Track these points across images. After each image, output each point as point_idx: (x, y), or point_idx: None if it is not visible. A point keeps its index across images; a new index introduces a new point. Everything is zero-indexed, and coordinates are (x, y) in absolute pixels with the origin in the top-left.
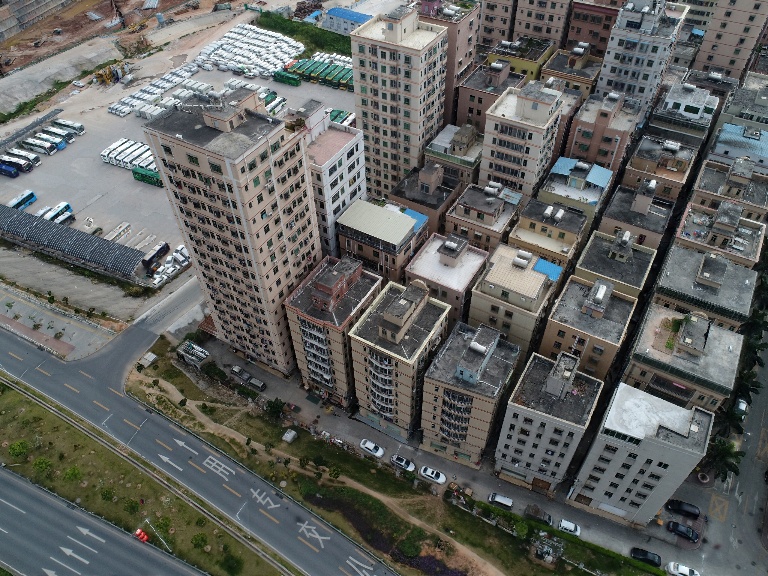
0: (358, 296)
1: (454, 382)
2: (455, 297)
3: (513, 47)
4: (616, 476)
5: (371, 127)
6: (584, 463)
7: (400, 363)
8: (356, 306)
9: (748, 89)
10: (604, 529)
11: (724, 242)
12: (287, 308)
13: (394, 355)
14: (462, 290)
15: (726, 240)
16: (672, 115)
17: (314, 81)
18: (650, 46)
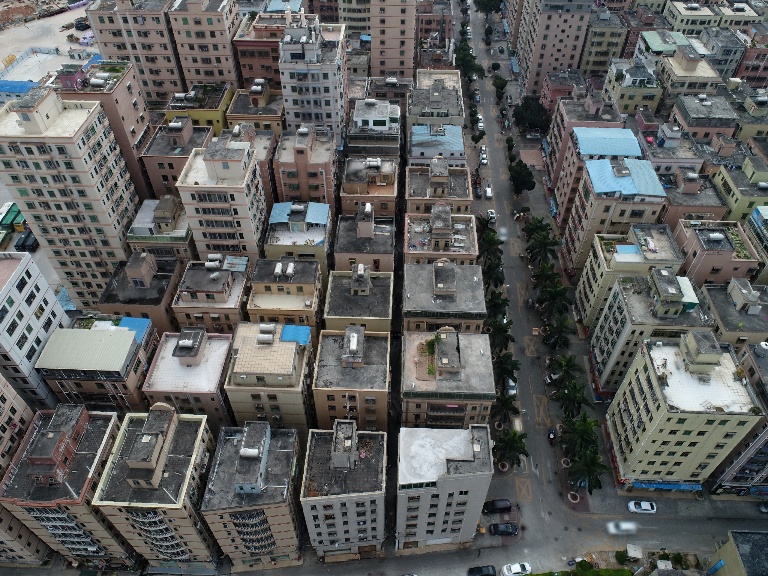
0: (93, 447)
1: (237, 501)
2: (210, 399)
3: (189, 98)
4: (429, 516)
5: (52, 229)
6: (397, 518)
7: (167, 510)
8: (93, 462)
9: (422, 87)
10: (438, 564)
11: (446, 244)
12: (1, 502)
13: (156, 506)
14: (214, 390)
15: (447, 242)
16: (364, 132)
17: None
18: (320, 74)
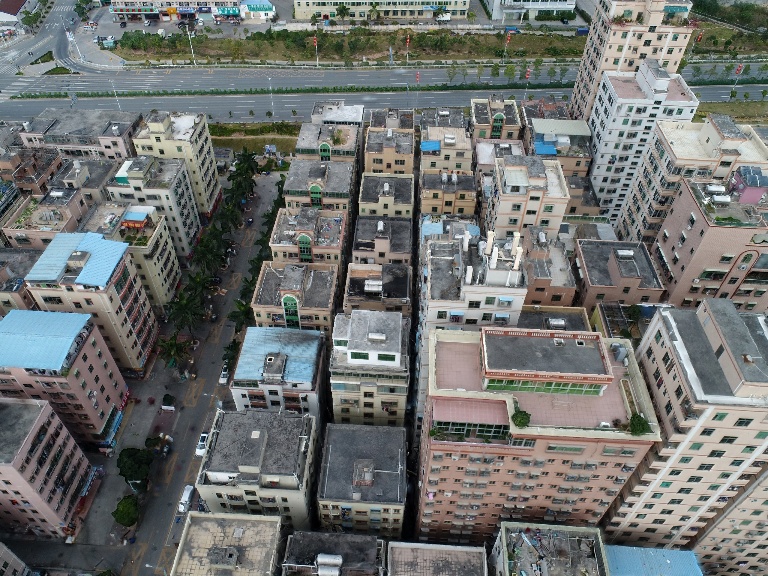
0: None
1: None
2: None
3: None
4: None
5: None
6: None
7: None
8: None
9: None
10: None
11: None
12: None
13: None
14: None
15: None
16: None
17: None
18: None
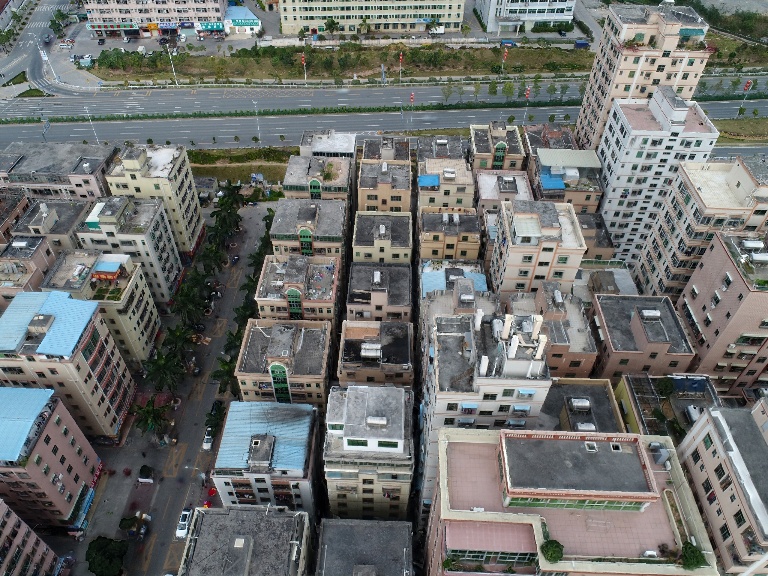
0: None
1: None
2: None
3: None
4: None
5: None
6: None
7: None
8: None
9: None
10: None
11: None
12: None
13: None
14: None
15: None
16: None
17: None
18: None
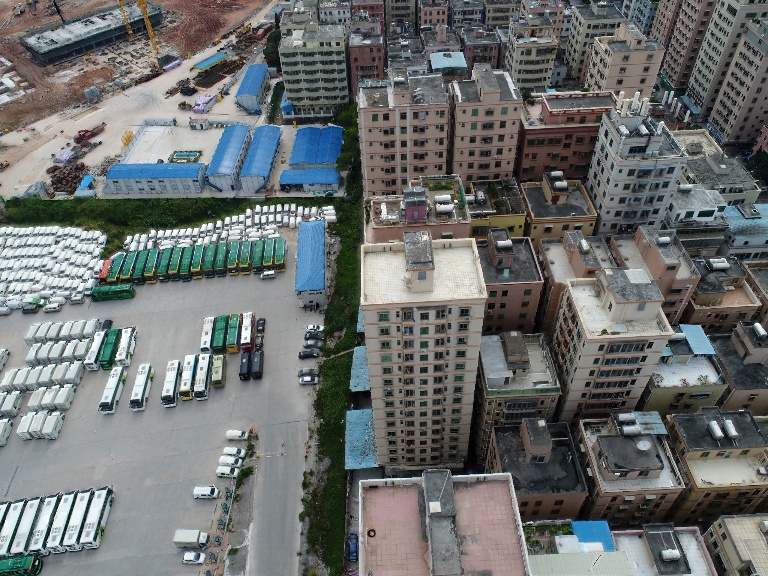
0: None
1: None
2: None
3: (480, 201)
4: None
5: (398, 392)
6: None
7: None
8: None
9: None
10: None
11: None
12: None
13: None
14: None
15: None
16: (689, 226)
17: (152, 281)
18: (667, 169)
